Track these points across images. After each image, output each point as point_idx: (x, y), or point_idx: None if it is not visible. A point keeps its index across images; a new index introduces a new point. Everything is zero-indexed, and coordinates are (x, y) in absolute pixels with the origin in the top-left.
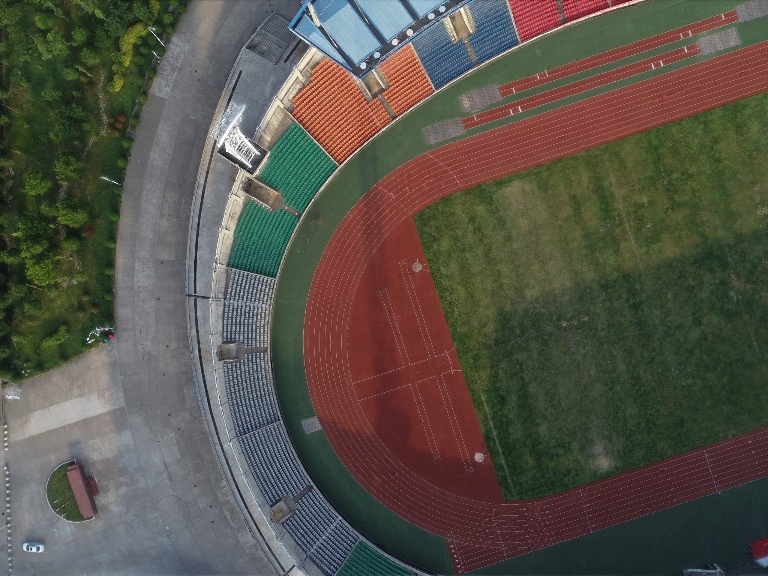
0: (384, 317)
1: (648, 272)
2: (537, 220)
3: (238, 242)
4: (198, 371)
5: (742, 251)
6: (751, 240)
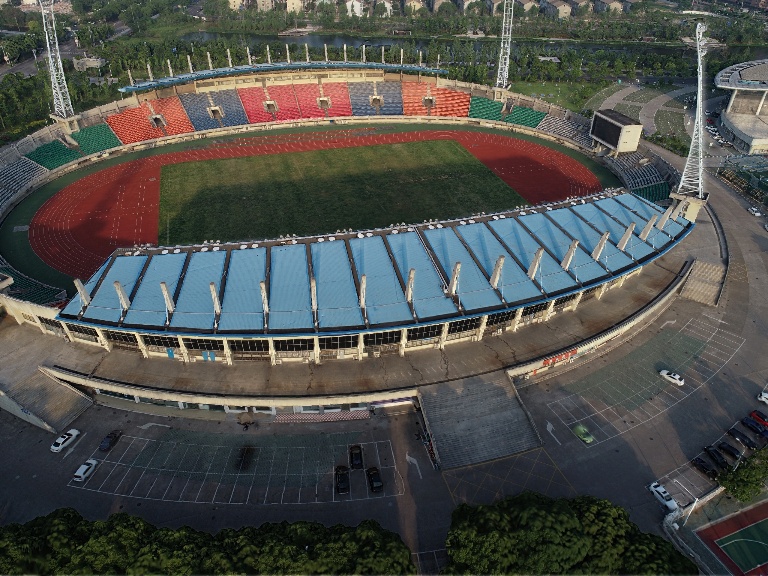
0: (116, 193)
1: (310, 184)
2: (241, 169)
3: (37, 151)
4: None
5: (374, 180)
6: (381, 177)
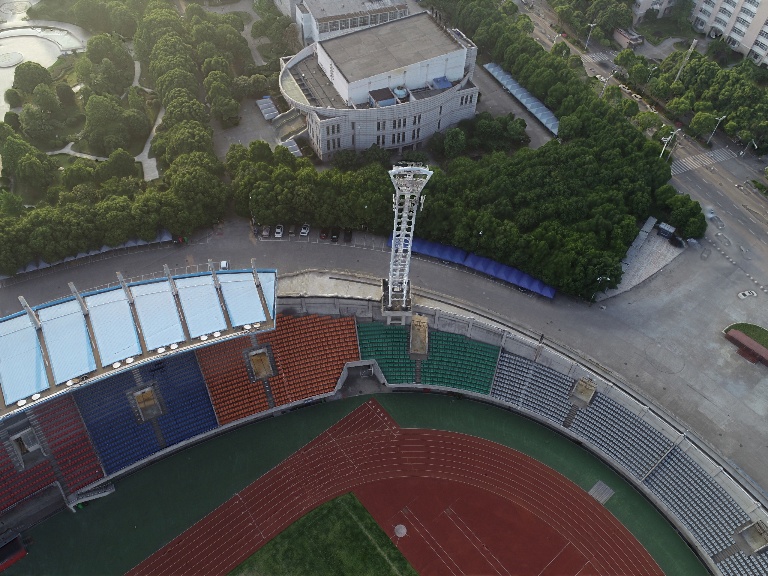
0: None
1: None
2: None
3: None
4: (764, 501)
5: None
6: None
